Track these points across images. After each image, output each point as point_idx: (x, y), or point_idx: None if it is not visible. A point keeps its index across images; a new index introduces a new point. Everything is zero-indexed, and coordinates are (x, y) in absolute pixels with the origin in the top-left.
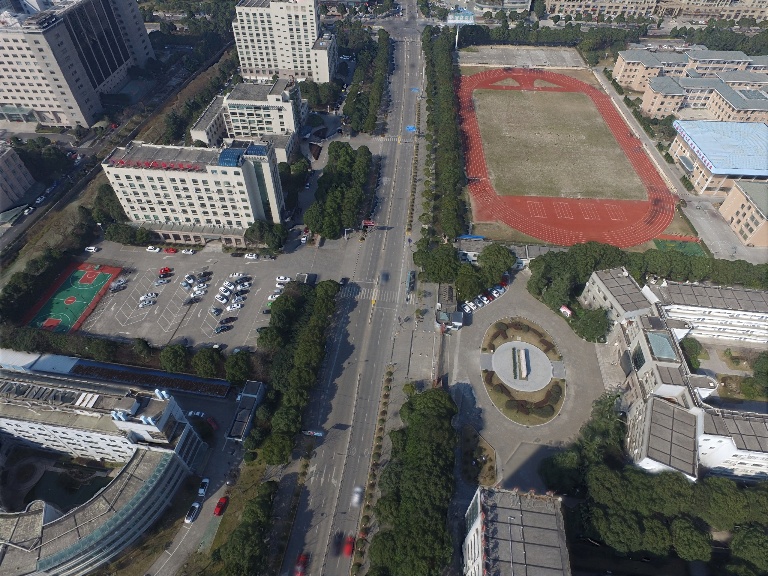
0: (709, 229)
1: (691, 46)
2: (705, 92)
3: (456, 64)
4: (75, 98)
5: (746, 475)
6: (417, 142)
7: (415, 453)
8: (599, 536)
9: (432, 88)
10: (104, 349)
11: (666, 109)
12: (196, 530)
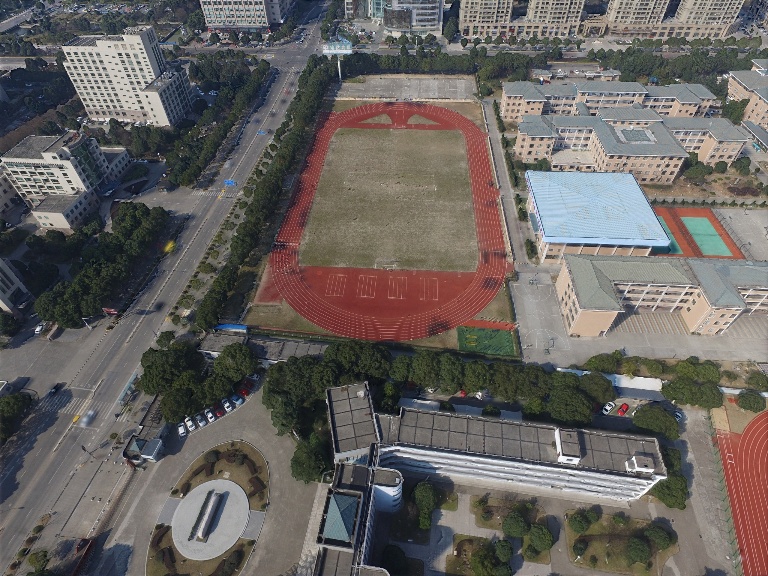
0: (533, 312)
1: (603, 71)
2: (583, 132)
3: (332, 98)
4: None
5: None
6: (240, 197)
7: None
8: None
9: (283, 130)
10: None
11: (538, 152)
12: None
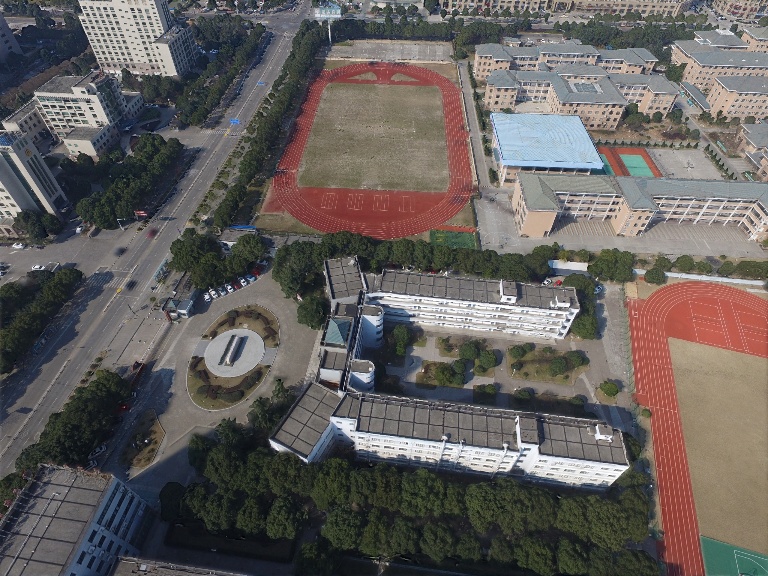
0: (492, 220)
1: (565, 40)
2: (542, 85)
3: (323, 58)
4: None
5: (392, 458)
6: (244, 135)
7: (53, 434)
8: (194, 514)
9: (280, 82)
10: None
11: (503, 102)
12: None
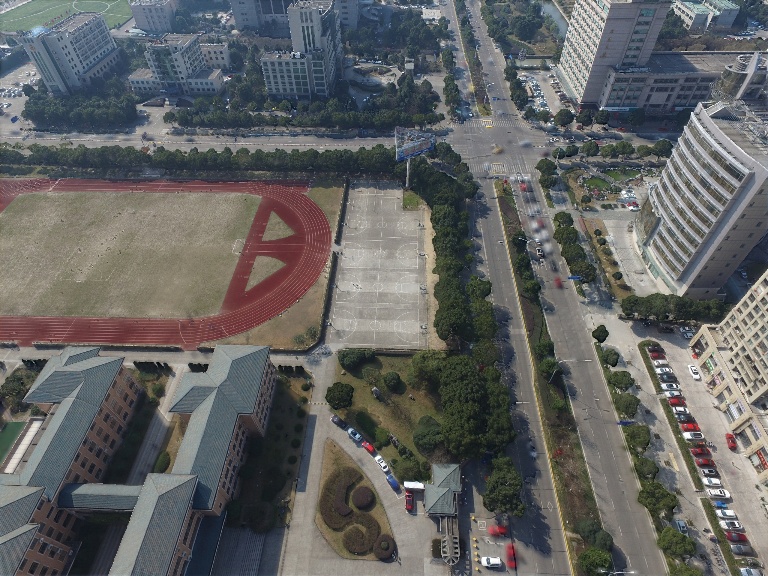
0: None
1: None
2: None
3: None
4: (233, 7)
5: None
6: None
7: None
8: None
9: (241, 151)
10: None
11: None
12: None
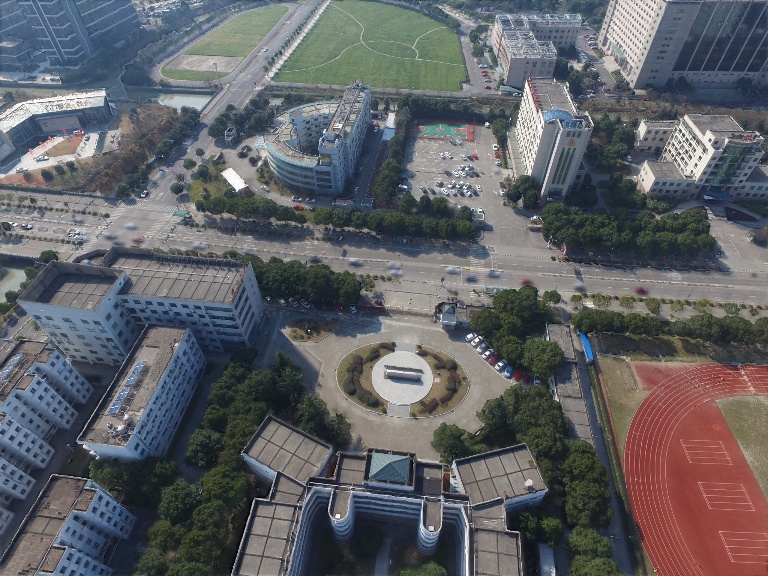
0: None
1: None
2: None
3: None
4: (645, 62)
5: None
6: None
7: None
8: None
9: None
10: (393, 141)
11: None
12: (288, 202)
